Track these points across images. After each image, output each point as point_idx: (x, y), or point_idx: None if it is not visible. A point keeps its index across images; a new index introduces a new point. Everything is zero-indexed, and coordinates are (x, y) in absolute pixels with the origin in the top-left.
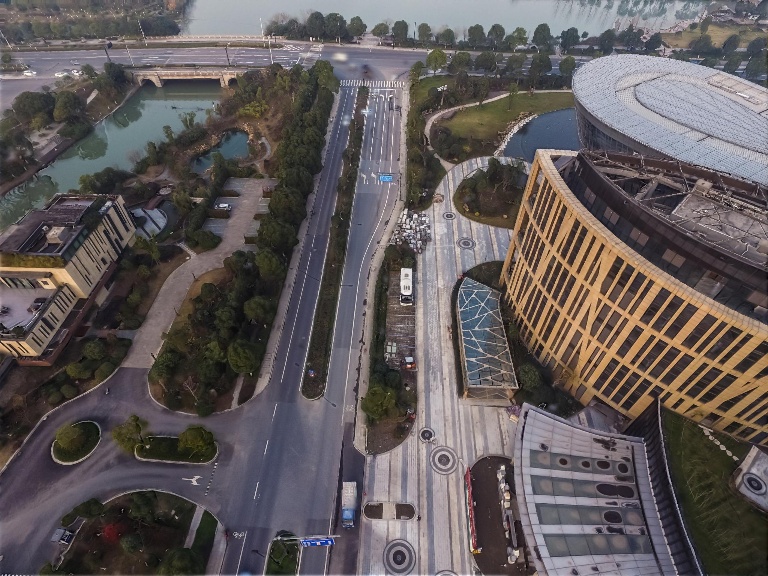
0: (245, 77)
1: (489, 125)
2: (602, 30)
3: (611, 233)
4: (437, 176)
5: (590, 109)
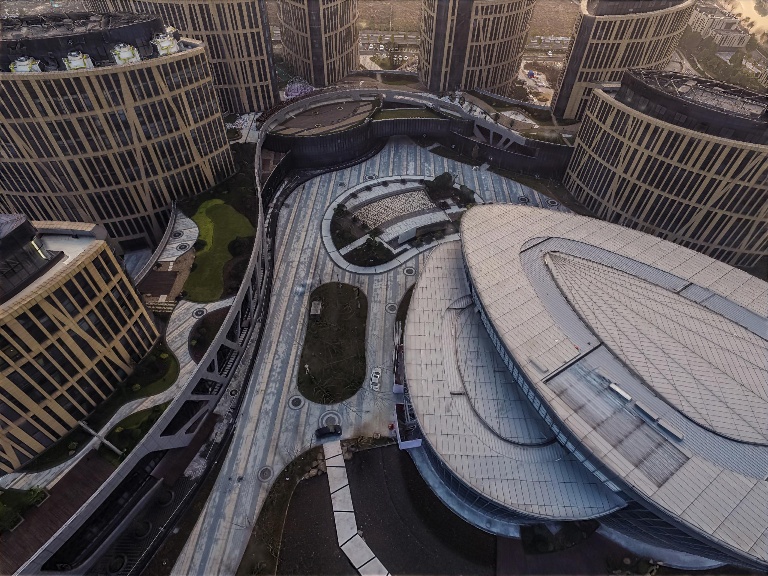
0: None
1: None
2: None
3: None
4: None
5: None
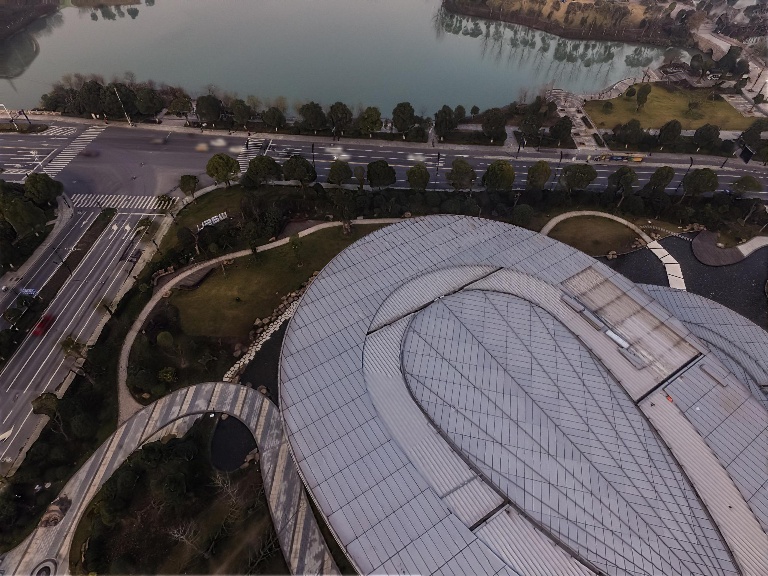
0: None
1: (250, 302)
2: (537, 77)
3: None
4: (83, 447)
5: (283, 400)
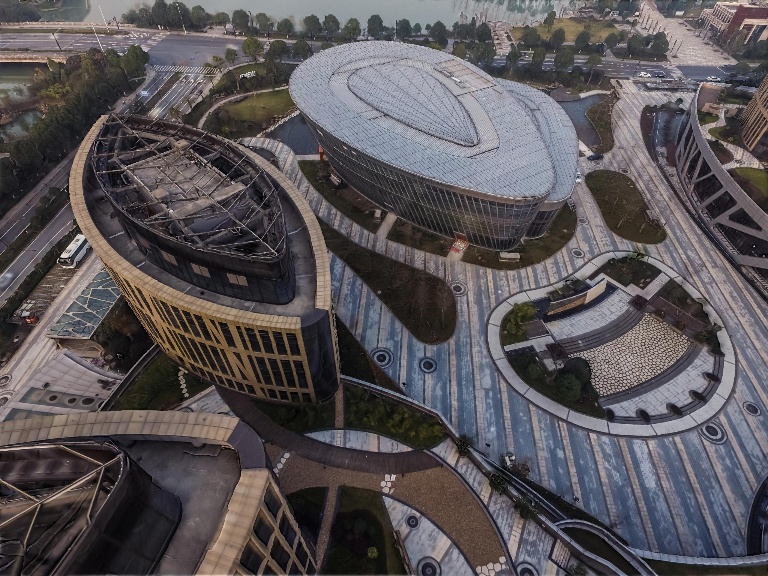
0: (67, 61)
1: (271, 109)
2: None
3: (81, 186)
4: None
5: (291, 89)
